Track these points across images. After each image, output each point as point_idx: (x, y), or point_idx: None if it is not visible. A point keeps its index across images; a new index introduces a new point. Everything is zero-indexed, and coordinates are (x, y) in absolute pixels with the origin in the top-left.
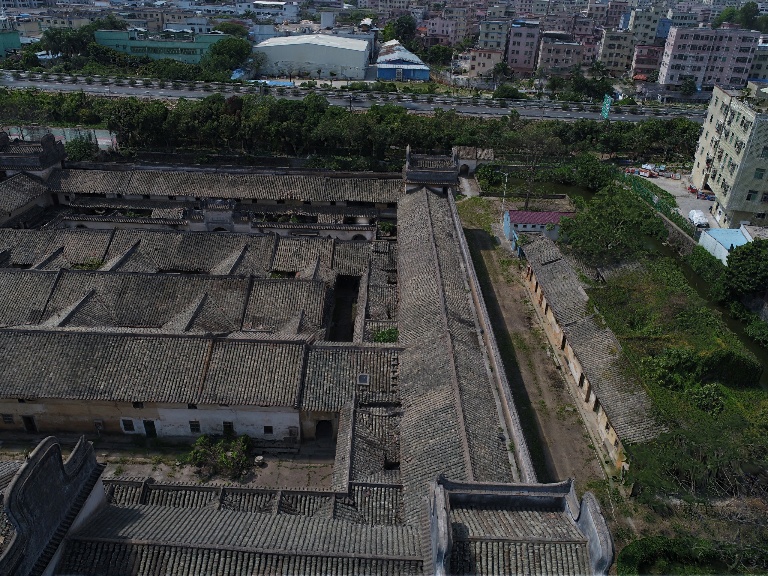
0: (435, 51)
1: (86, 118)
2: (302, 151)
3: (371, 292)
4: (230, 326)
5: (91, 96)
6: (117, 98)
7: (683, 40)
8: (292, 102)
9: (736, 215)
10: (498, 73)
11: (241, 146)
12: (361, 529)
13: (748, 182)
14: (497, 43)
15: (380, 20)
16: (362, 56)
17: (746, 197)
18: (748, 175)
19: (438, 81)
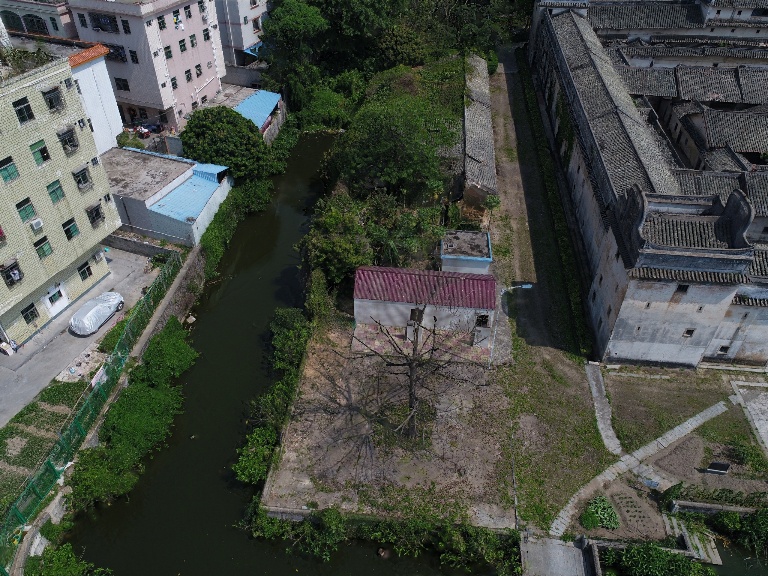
0: None
1: None
2: None
3: (661, 139)
4: None
5: None
6: None
7: None
8: None
9: None
10: None
11: None
12: (608, 21)
13: None
14: None
15: None
16: None
17: None
18: None
19: None
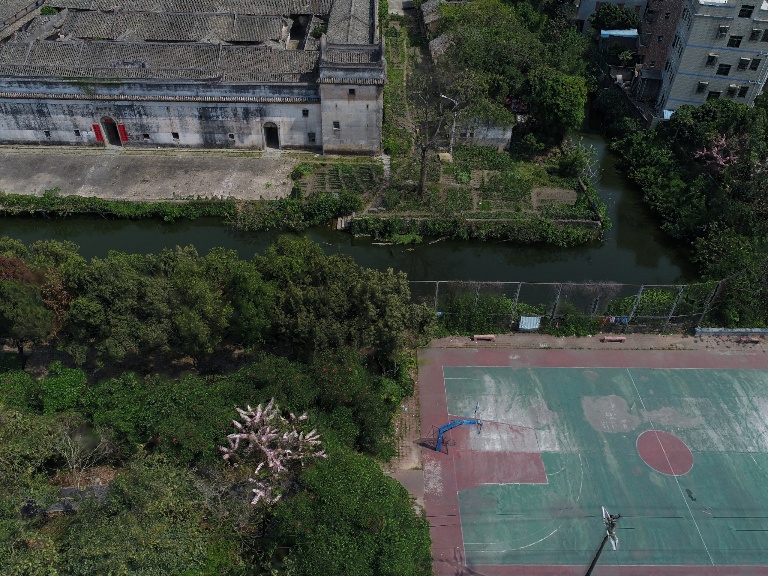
0: None
1: None
2: None
3: None
4: None
5: None
6: None
7: None
8: None
9: None
10: None
11: None
12: None
13: None
14: None
15: None
16: None
17: None
18: None
19: None
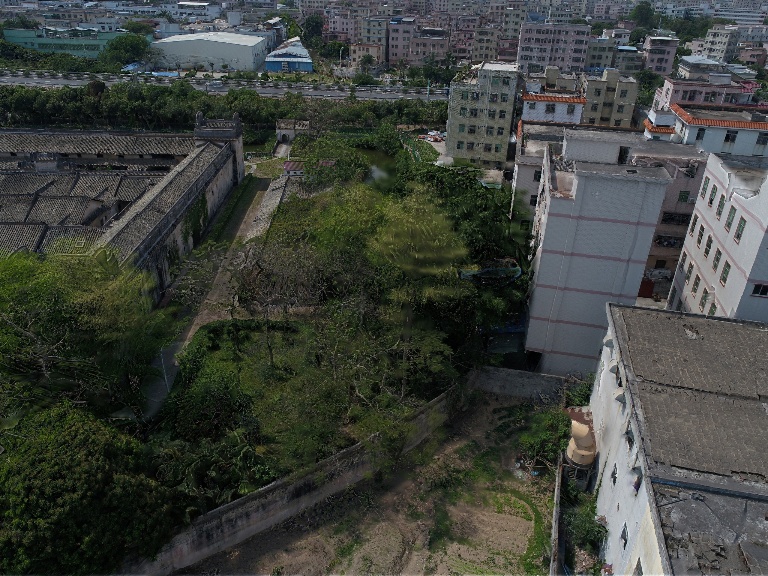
0: (332, 47)
1: None
2: (159, 127)
3: None
4: None
5: None
6: (9, 86)
7: (528, 34)
8: (158, 87)
9: (456, 161)
10: (365, 64)
11: (107, 123)
12: None
13: (456, 135)
14: (378, 38)
15: (290, 19)
16: (251, 50)
17: (457, 147)
18: (455, 130)
19: (320, 72)
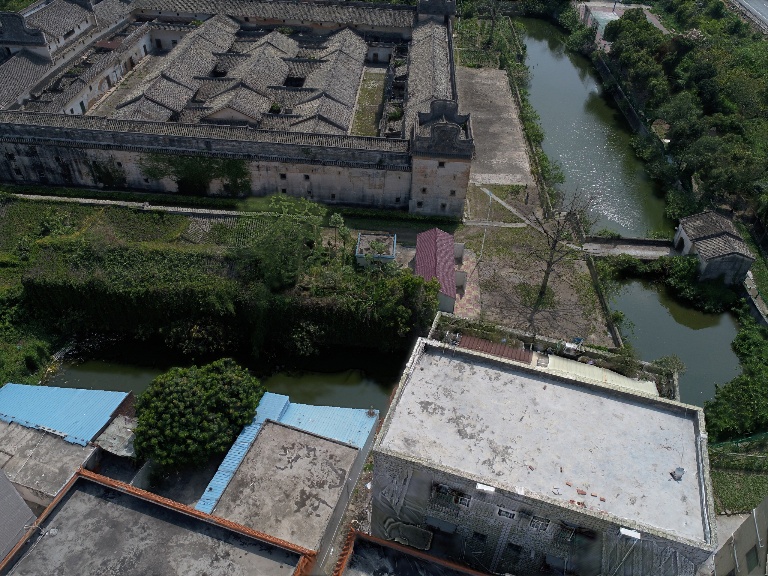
0: None
1: (687, 25)
2: None
3: None
4: (211, 95)
5: (737, 10)
6: (748, 19)
7: None
8: None
9: None
10: None
11: None
12: None
13: None
14: None
15: None
16: None
17: None
18: None
19: None
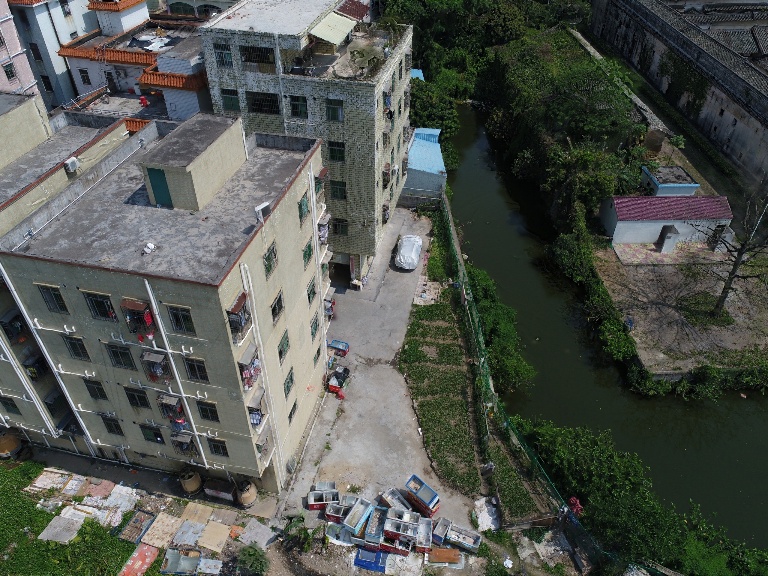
0: None
1: None
2: None
3: None
4: None
5: None
6: None
7: None
8: None
9: None
10: None
11: None
12: None
13: None
14: None
15: None
16: None
17: None
18: None
19: None
